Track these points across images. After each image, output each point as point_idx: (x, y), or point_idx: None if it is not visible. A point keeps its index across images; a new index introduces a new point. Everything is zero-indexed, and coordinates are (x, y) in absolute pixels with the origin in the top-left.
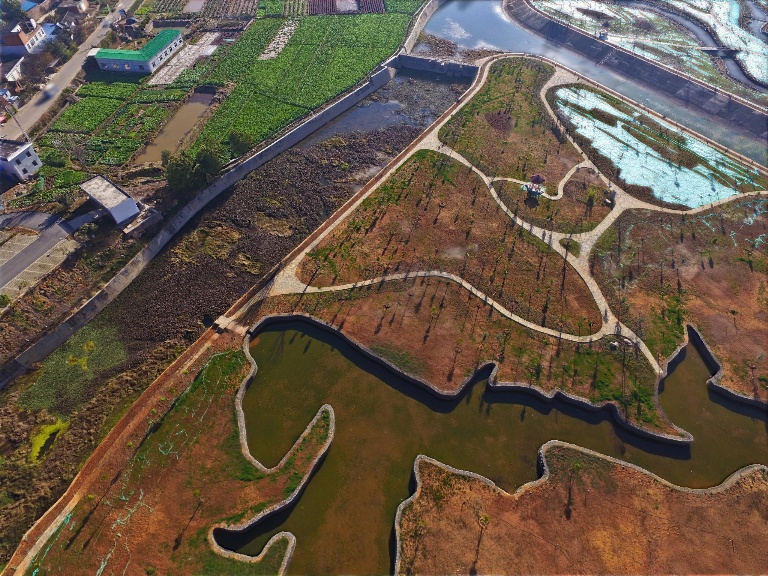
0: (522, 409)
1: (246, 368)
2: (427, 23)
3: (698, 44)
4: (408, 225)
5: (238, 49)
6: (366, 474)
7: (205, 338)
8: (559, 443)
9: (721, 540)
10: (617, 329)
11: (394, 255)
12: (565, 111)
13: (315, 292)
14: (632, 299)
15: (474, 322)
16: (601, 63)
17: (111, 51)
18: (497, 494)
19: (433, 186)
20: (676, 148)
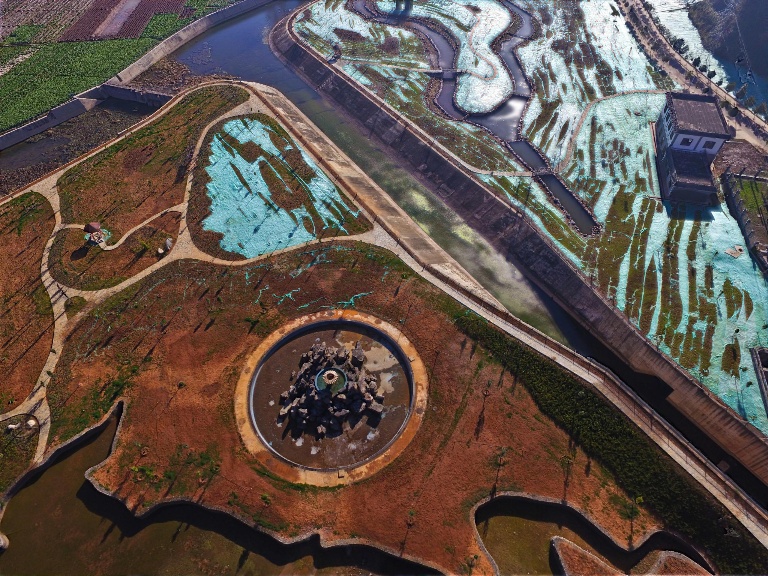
0: None
1: None
2: (180, 47)
3: (431, 66)
4: None
5: None
6: None
7: None
8: None
9: None
10: (34, 408)
11: None
12: (214, 146)
13: None
14: (85, 370)
15: None
16: (319, 88)
17: None
18: None
19: None
20: (294, 187)
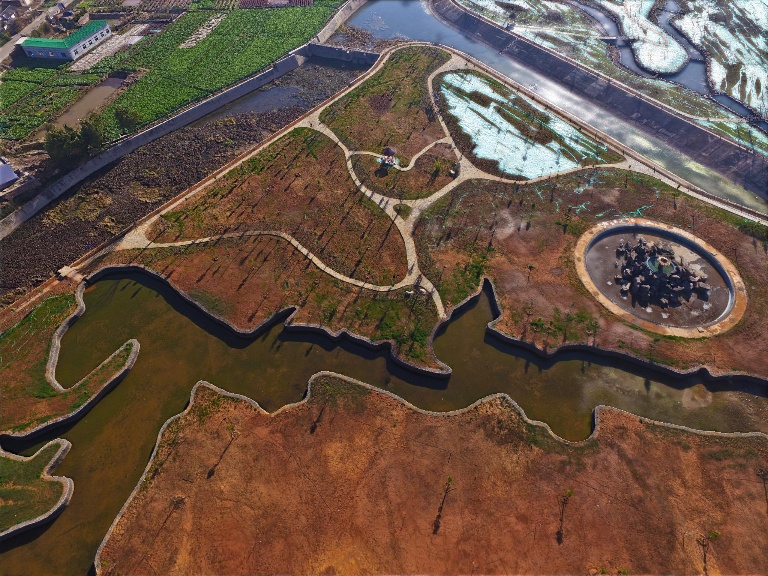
0: (310, 346)
1: (72, 308)
2: (351, 16)
3: (601, 34)
4: (261, 192)
5: (161, 39)
6: (151, 396)
7: (46, 284)
8: (328, 373)
9: (441, 452)
10: (417, 280)
11: (239, 217)
12: (445, 94)
13: (156, 247)
14: (442, 256)
15: (290, 273)
16: (503, 52)
17: (37, 40)
18: (257, 412)
19: (297, 159)
20: None
